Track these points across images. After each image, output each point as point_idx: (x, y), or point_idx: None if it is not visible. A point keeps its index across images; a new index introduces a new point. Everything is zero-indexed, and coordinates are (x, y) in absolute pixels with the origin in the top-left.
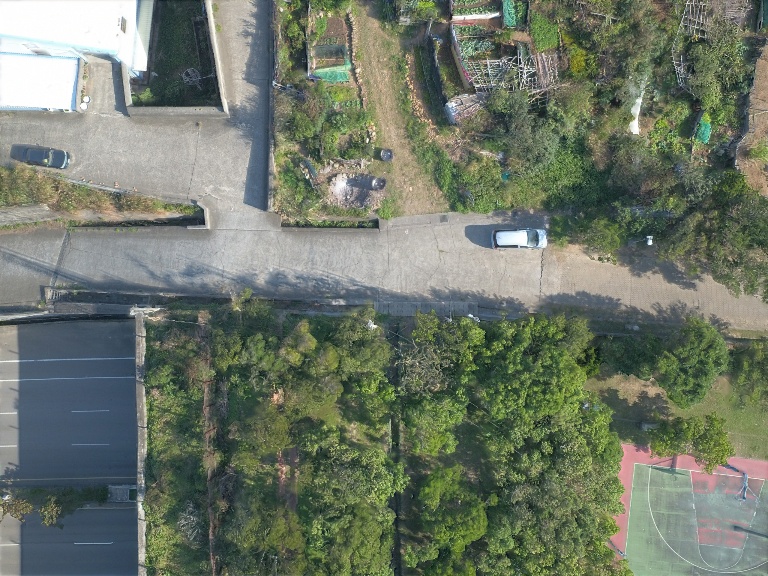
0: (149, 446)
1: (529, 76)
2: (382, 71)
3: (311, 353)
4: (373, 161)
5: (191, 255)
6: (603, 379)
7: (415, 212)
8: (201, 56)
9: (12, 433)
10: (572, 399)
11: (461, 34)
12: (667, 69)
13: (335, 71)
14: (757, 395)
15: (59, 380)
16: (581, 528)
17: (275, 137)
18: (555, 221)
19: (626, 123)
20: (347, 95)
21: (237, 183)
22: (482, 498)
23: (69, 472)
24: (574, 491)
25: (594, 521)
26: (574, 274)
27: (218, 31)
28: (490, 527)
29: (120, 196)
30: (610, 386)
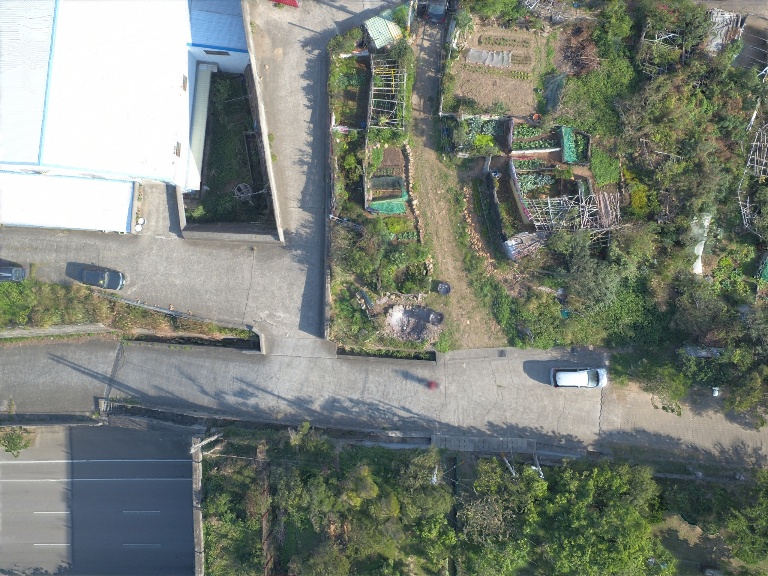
0: (206, 570)
1: (591, 215)
2: (439, 203)
3: (371, 498)
4: (430, 293)
5: (246, 379)
6: (663, 519)
7: (472, 346)
8: (253, 170)
9: (65, 532)
10: (636, 555)
11: (520, 168)
12: (732, 208)
13: (392, 202)
14: None
15: (111, 481)
16: None
17: (332, 269)
18: (615, 359)
19: (690, 264)
20: (404, 226)
21: (292, 309)
22: None
23: (121, 571)
24: None
25: None
26: (634, 413)
27: (274, 161)
28: None
29: (175, 319)
30: (670, 526)
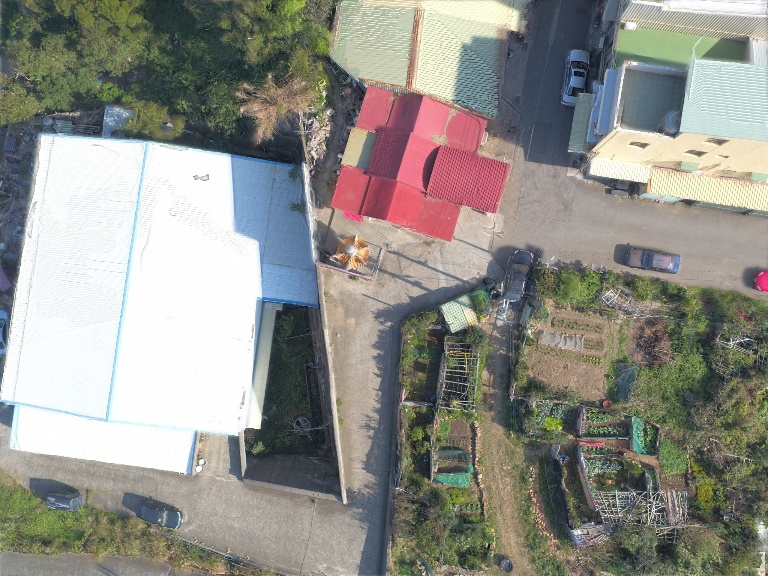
0: None
1: (658, 511)
2: (505, 479)
3: None
4: None
5: None
6: None
7: None
8: (312, 403)
9: None
10: None
11: (588, 452)
12: None
13: None
14: None
15: None
16: None
17: (395, 539)
18: None
19: (754, 566)
20: (468, 498)
21: (351, 565)
22: None
23: None
24: None
25: None
26: None
27: (341, 425)
28: None
29: None
30: None
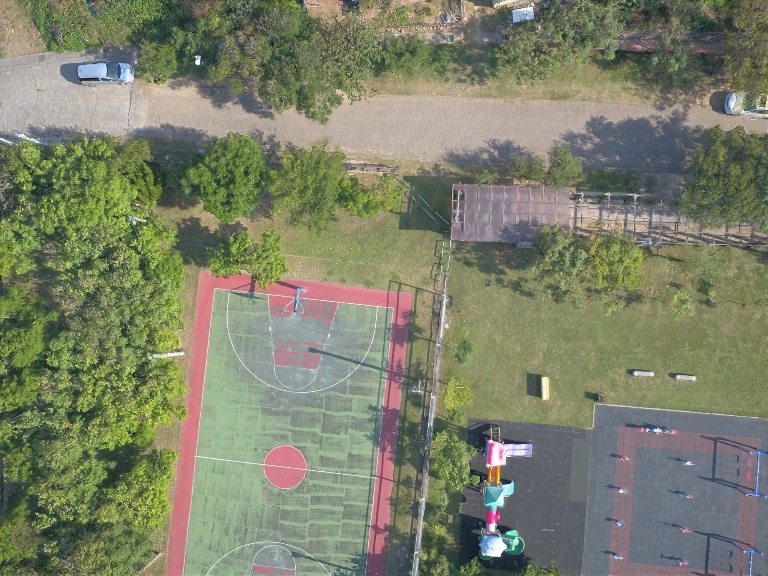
0: None
1: None
2: None
3: None
4: None
5: None
6: (186, 208)
7: (16, 53)
8: None
9: None
10: (113, 211)
11: None
12: None
13: None
14: (287, 203)
15: None
16: (126, 337)
17: None
18: None
19: None
20: None
21: None
22: (43, 314)
23: None
24: (125, 304)
25: (142, 332)
26: (159, 107)
27: None
28: (46, 340)
29: None
30: (192, 214)
